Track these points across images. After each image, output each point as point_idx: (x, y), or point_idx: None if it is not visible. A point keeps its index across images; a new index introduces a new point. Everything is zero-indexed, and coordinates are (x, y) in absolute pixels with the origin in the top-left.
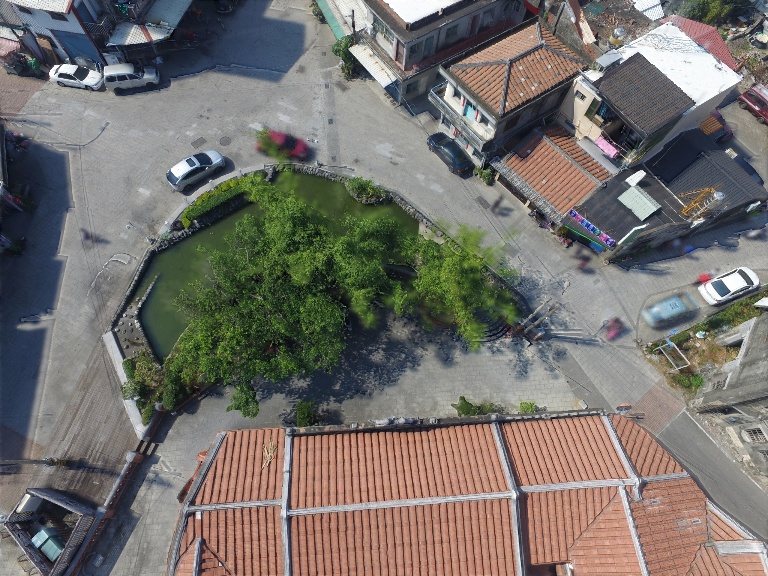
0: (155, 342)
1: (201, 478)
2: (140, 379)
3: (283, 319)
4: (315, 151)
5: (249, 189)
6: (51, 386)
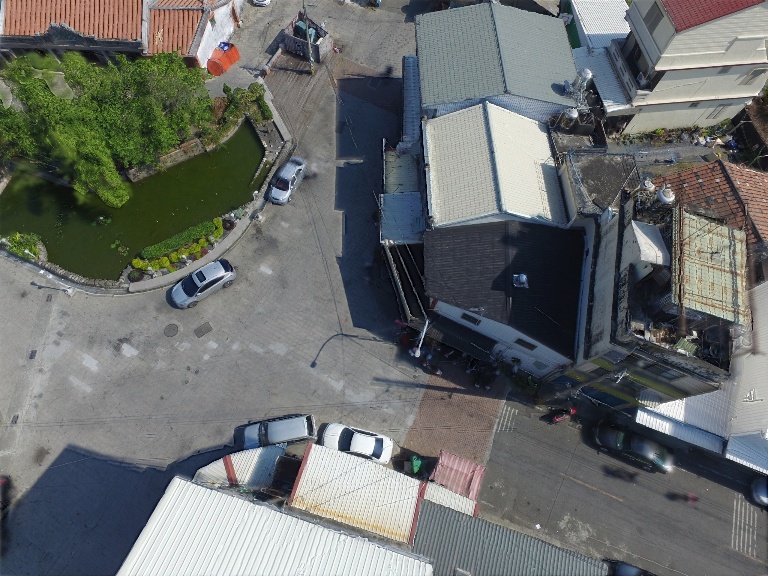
0: (253, 135)
1: (200, 25)
2: (250, 93)
3: (112, 76)
4: (68, 311)
5: (109, 172)
6: (331, 117)
